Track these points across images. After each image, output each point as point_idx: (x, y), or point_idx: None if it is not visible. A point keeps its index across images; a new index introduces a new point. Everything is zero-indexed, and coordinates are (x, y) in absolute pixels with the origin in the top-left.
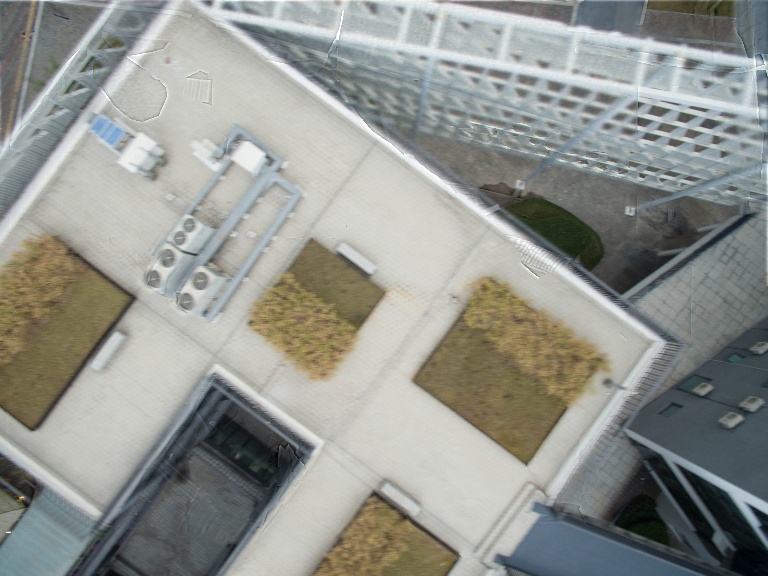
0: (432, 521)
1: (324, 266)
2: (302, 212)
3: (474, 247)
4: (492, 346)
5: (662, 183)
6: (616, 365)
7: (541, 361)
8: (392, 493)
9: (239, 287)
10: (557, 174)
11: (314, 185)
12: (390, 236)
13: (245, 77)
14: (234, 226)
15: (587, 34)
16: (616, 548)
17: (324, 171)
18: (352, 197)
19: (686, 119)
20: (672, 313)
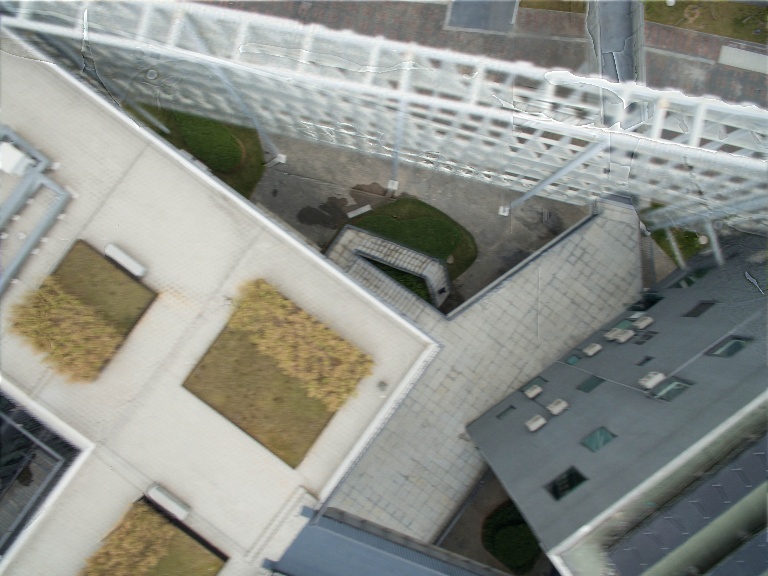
0: (202, 524)
1: (92, 268)
2: (74, 213)
3: (248, 248)
4: (260, 348)
5: (509, 183)
6: (390, 367)
7: (312, 363)
8: (157, 496)
9: (8, 289)
10: (431, 174)
11: (86, 186)
12: (163, 237)
13: (19, 78)
14: (2, 227)
15: (462, 33)
16: (372, 553)
17: (97, 172)
18: (124, 198)
19: (562, 118)
20: (519, 314)
